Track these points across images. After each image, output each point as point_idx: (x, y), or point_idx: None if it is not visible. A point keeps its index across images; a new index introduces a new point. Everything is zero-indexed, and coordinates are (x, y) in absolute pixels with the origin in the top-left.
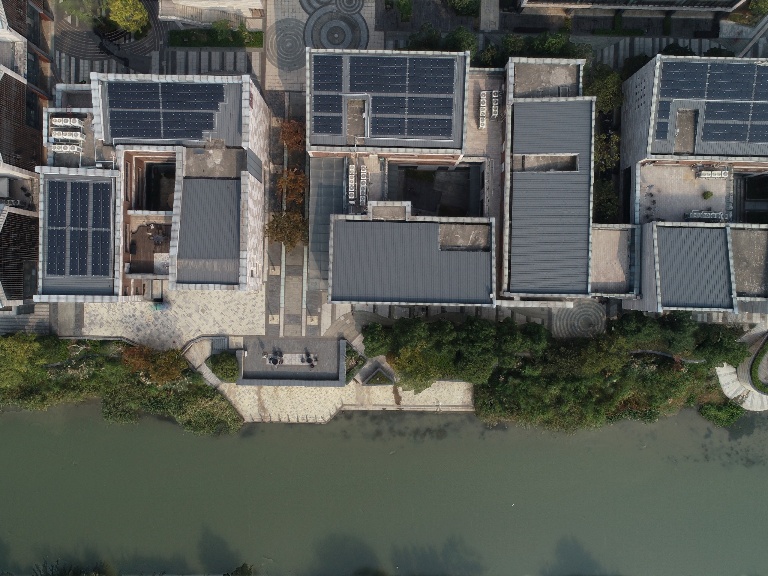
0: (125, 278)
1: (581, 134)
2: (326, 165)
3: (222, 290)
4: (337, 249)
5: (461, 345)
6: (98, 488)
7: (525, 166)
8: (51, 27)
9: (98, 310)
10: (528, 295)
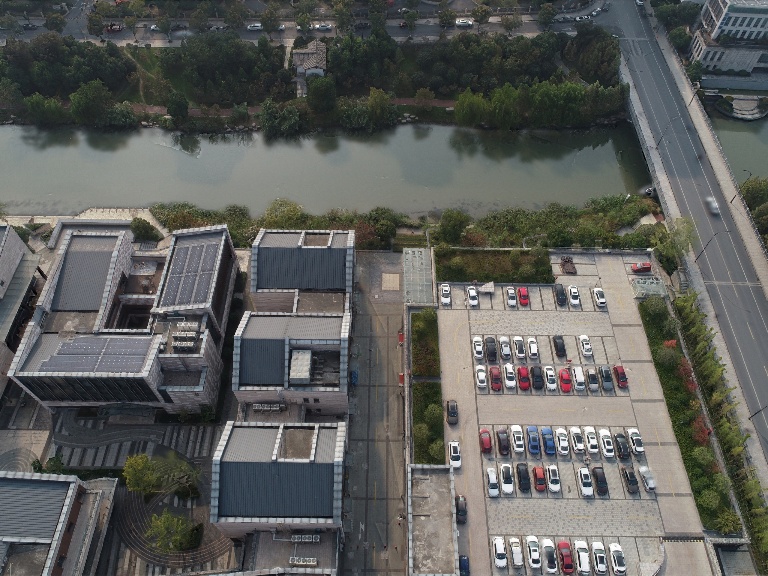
0: None
1: None
2: None
3: None
4: None
5: None
6: (264, 177)
7: None
8: None
9: None
10: None
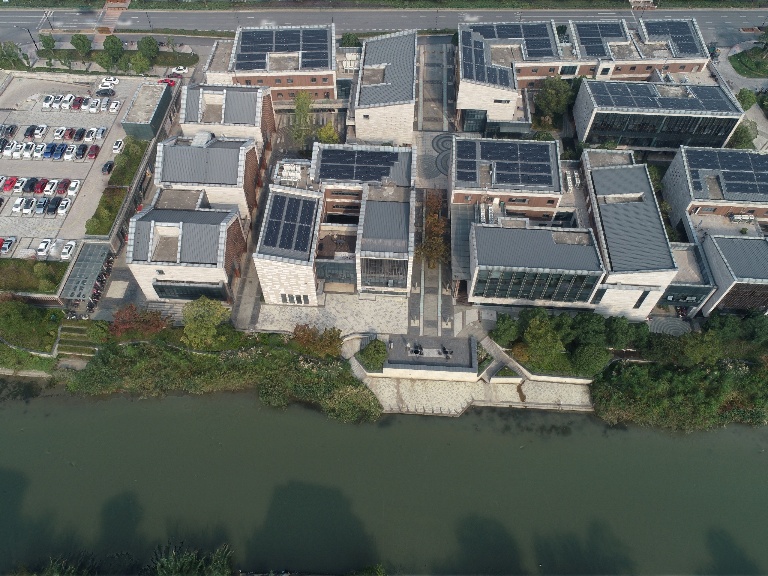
0: (314, 261)
1: (642, 183)
2: (462, 208)
3: (373, 302)
4: (478, 240)
5: (578, 328)
6: (238, 469)
7: (607, 202)
8: (269, 154)
9: (271, 312)
10: (629, 272)
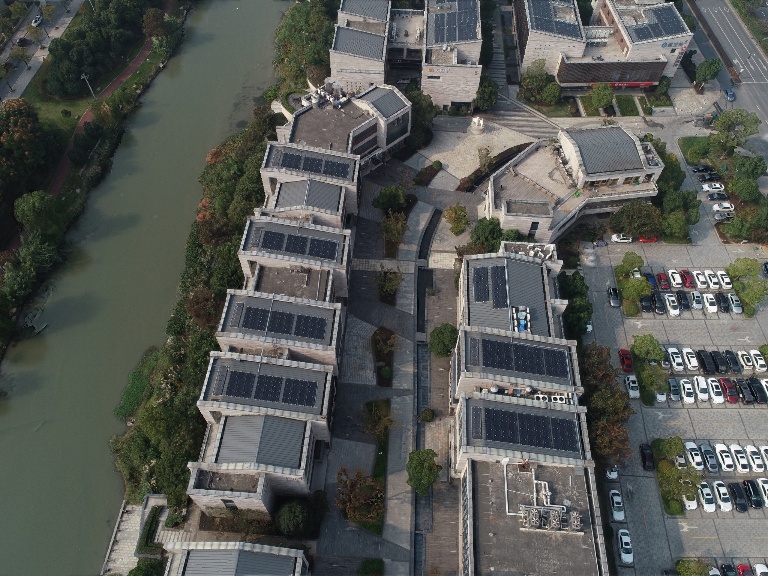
0: None
1: None
2: None
3: None
4: None
5: None
6: None
7: None
8: None
9: None
10: None
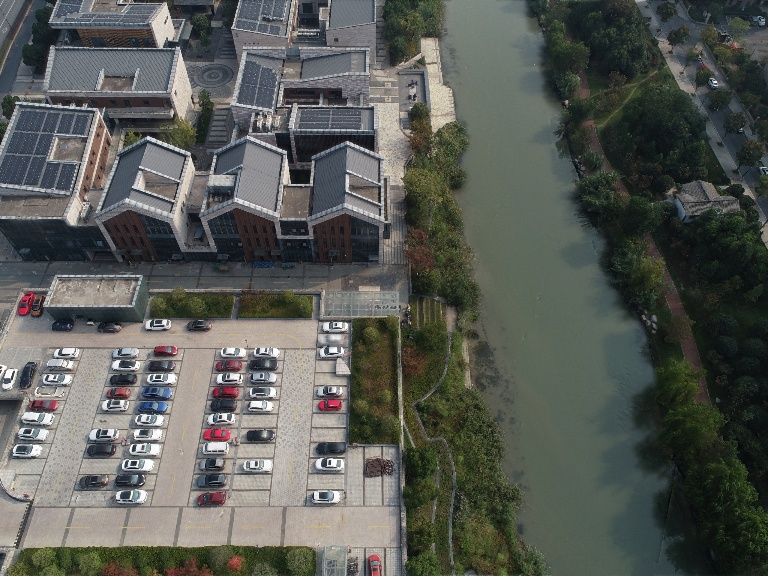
0: None
1: None
2: None
3: None
4: None
5: (398, 14)
6: (516, 195)
7: None
8: None
9: None
10: None
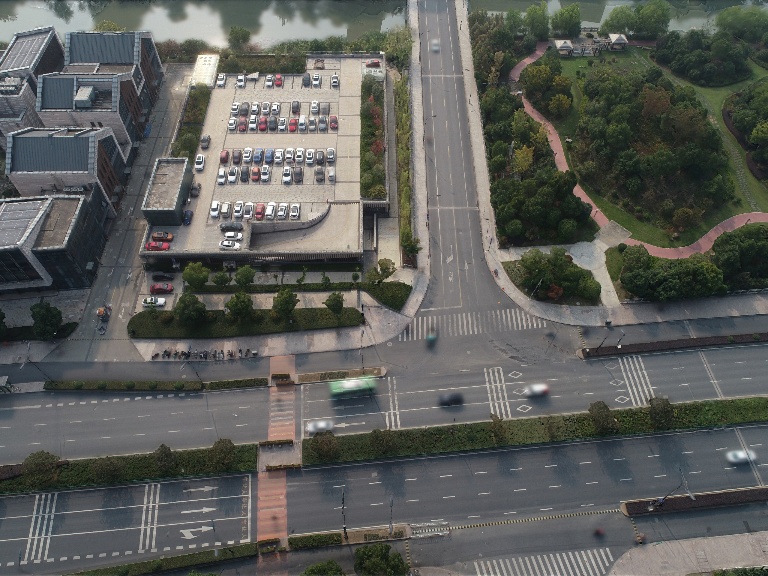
0: None
1: None
2: None
3: None
4: None
5: None
6: None
7: None
8: None
9: None
10: None
